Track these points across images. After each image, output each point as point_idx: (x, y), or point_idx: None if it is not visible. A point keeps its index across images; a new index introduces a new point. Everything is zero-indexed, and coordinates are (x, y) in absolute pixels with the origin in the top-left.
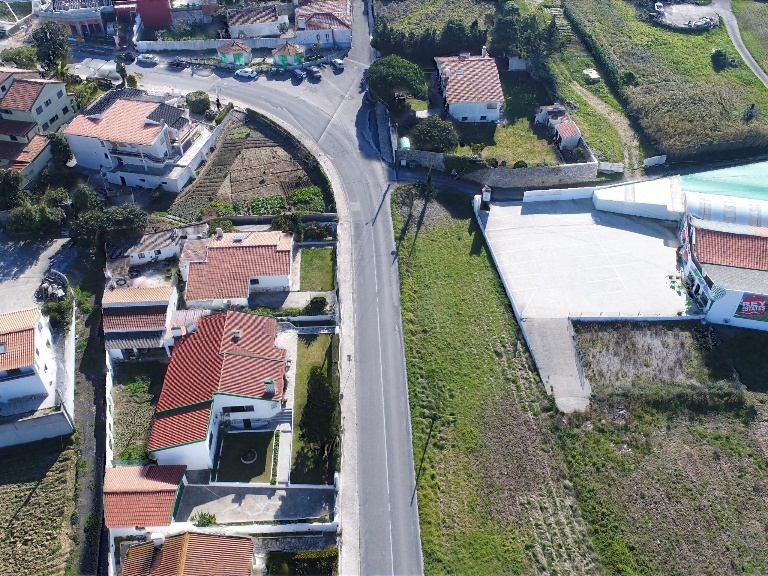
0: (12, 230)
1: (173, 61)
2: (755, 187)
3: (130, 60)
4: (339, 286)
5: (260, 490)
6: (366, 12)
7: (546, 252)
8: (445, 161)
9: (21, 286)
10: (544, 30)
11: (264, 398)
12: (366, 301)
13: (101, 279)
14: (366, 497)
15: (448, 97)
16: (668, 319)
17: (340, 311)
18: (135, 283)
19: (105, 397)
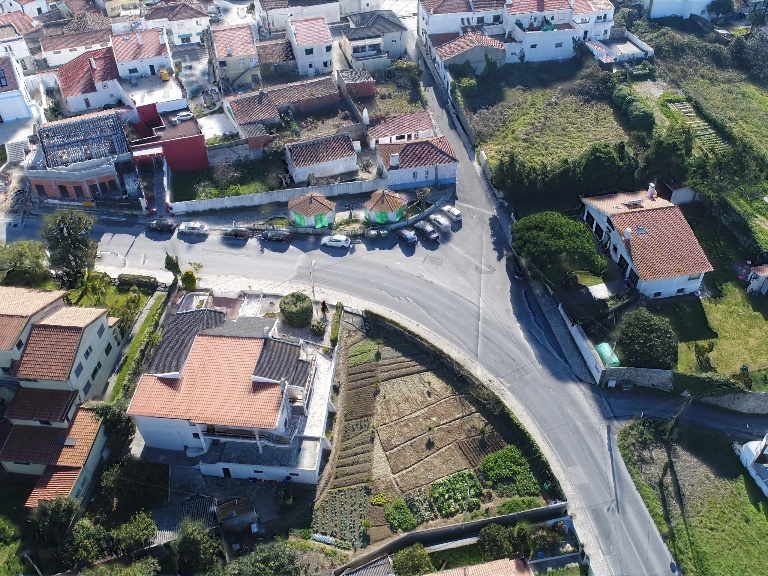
0: None
1: (227, 228)
2: None
3: (167, 232)
4: None
5: None
6: (452, 124)
7: None
8: (674, 380)
9: None
10: (728, 158)
11: None
12: None
13: None
14: None
15: (640, 272)
16: None
17: None
18: None
19: None
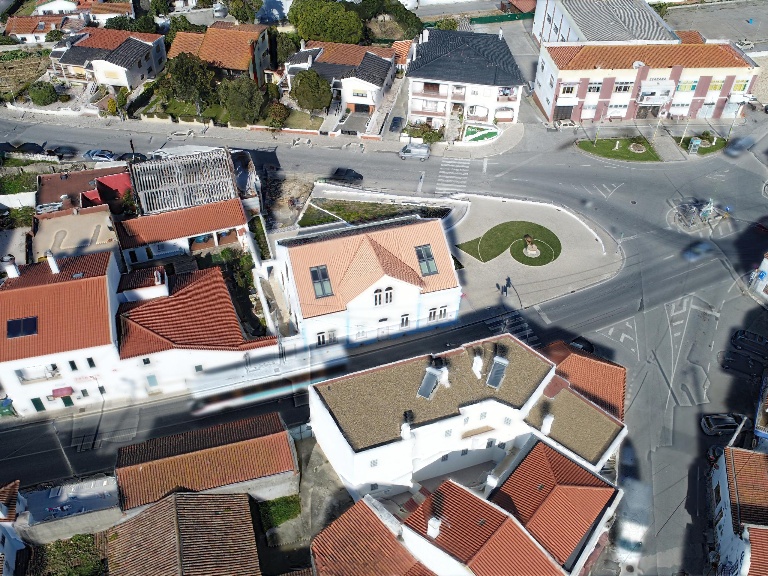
0: None
1: (67, 162)
2: None
3: None
4: None
5: None
6: None
7: None
8: None
9: None
10: None
11: None
12: None
13: None
14: None
15: None
16: None
17: None
18: None
19: (137, 7)
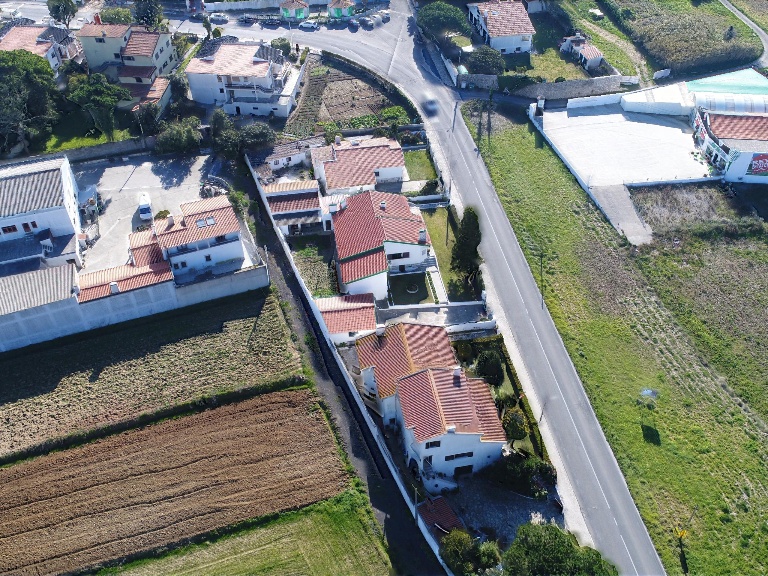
0: (161, 151)
1: (241, 18)
2: (744, 86)
3: None
4: (441, 175)
5: (428, 309)
6: None
7: (595, 142)
8: (499, 81)
9: (185, 190)
10: None
11: (420, 244)
12: (465, 184)
13: (248, 182)
14: (508, 307)
15: (490, 32)
16: (697, 181)
17: (450, 189)
18: (280, 181)
19: (284, 261)
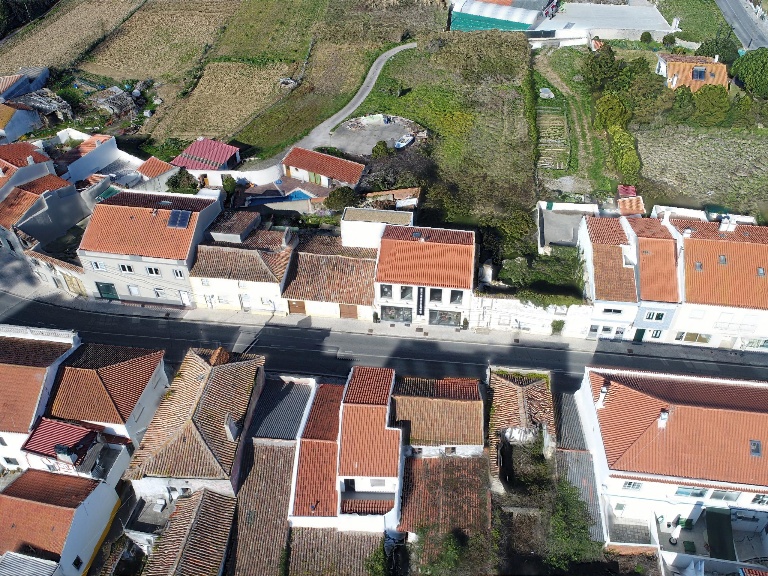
0: None
1: None
2: (481, 21)
3: None
4: None
5: None
6: None
7: None
8: None
9: None
10: None
11: None
12: (745, 18)
13: None
14: None
15: None
16: None
17: None
18: None
19: None
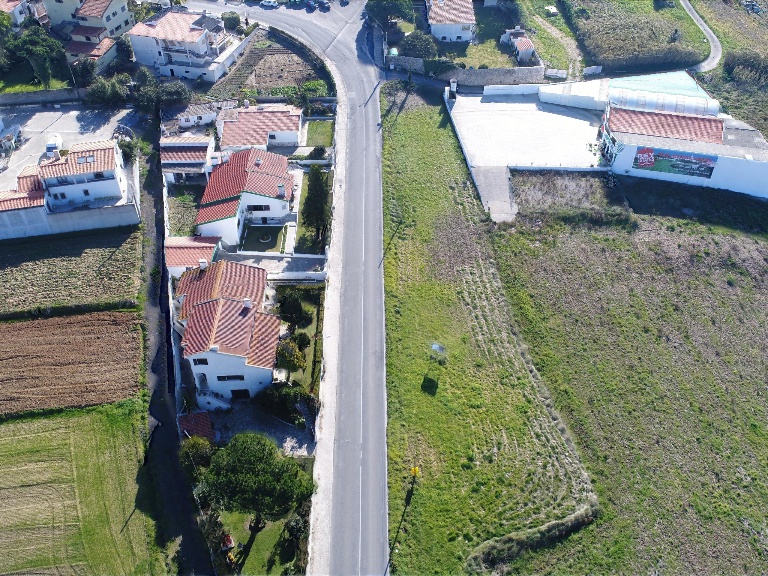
0: (89, 101)
1: None
2: (667, 87)
3: None
4: (336, 143)
5: (273, 257)
6: None
7: (497, 126)
8: (424, 65)
9: (98, 137)
10: None
11: (277, 198)
12: (356, 153)
13: (157, 135)
14: (347, 263)
15: (430, 19)
16: (583, 170)
17: None
18: (183, 136)
19: (162, 204)
